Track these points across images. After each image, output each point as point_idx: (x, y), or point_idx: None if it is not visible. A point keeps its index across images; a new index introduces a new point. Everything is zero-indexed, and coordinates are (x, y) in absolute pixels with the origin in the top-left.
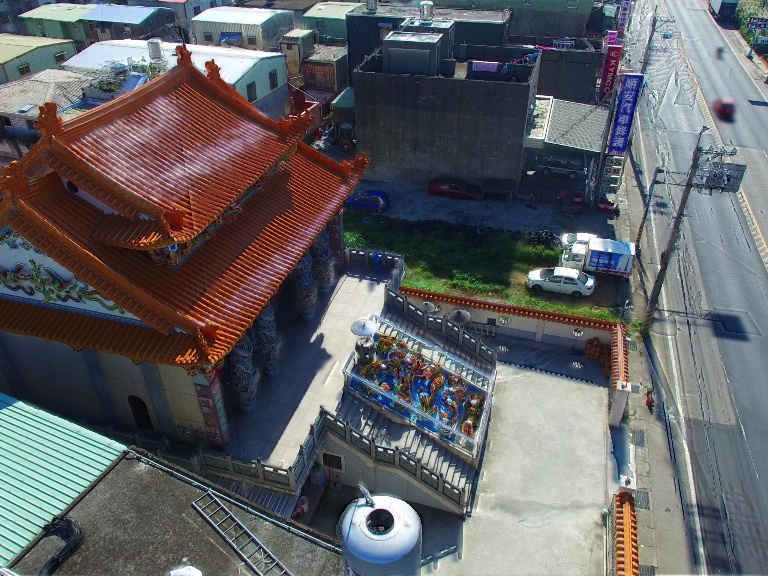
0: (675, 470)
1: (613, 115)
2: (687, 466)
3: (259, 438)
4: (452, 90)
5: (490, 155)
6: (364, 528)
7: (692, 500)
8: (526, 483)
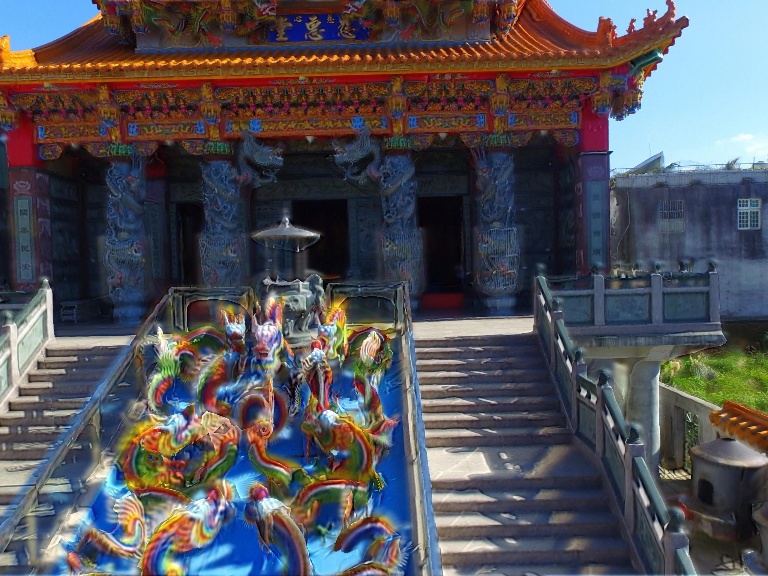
0: None
1: None
2: None
3: None
4: None
5: None
6: None
7: None
8: None
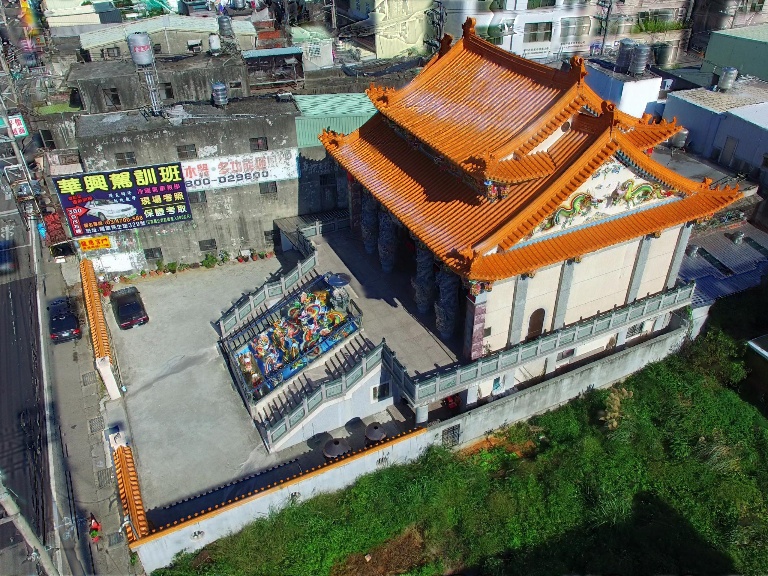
0: (67, 463)
1: None
2: (55, 473)
3: (345, 245)
4: None
5: None
6: None
7: (52, 444)
8: (191, 379)
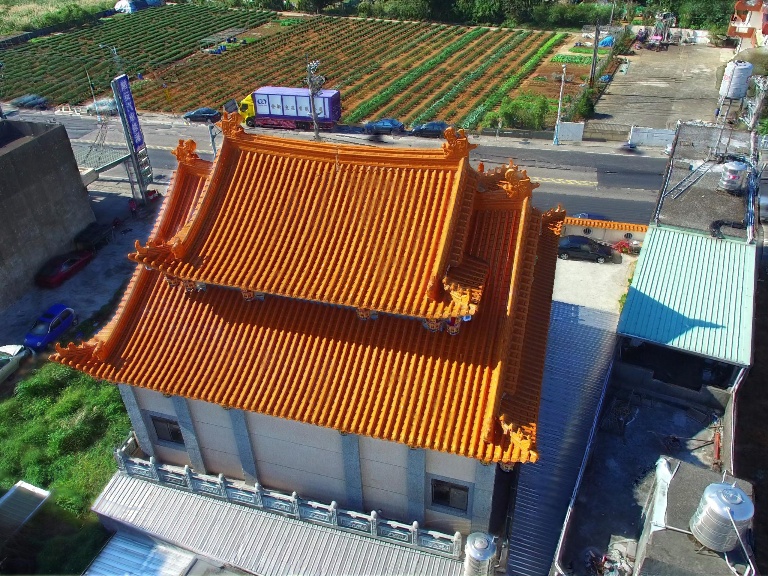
0: None
1: (125, 118)
2: None
3: None
4: (5, 169)
5: (66, 213)
6: (746, 63)
7: None
8: None
